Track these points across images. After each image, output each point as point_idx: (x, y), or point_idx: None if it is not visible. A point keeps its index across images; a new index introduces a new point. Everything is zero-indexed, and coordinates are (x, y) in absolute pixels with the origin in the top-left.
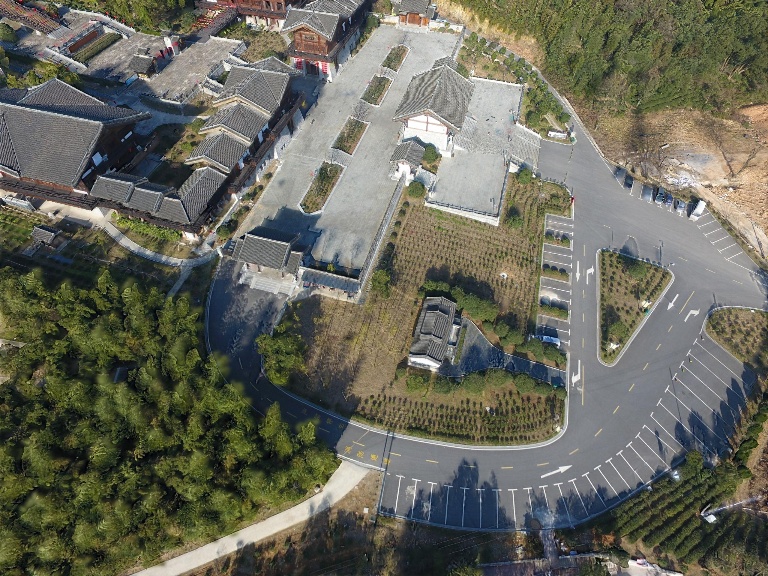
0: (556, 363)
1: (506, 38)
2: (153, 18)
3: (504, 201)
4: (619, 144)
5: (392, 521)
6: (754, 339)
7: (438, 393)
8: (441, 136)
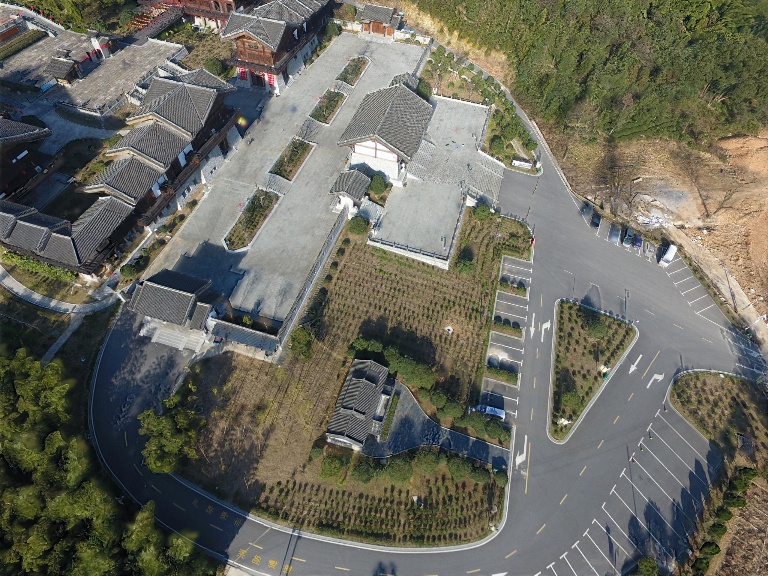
0: (499, 440)
1: (476, 53)
2: (88, 15)
3: (457, 240)
4: (588, 176)
5: None
6: (722, 411)
7: (356, 481)
8: (391, 164)
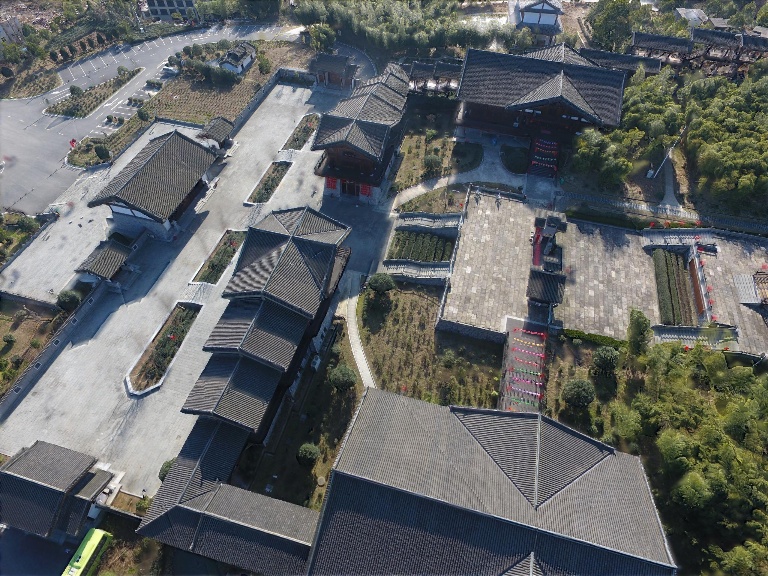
0: None
1: None
2: None
3: None
4: None
5: (277, 23)
6: None
7: None
8: None
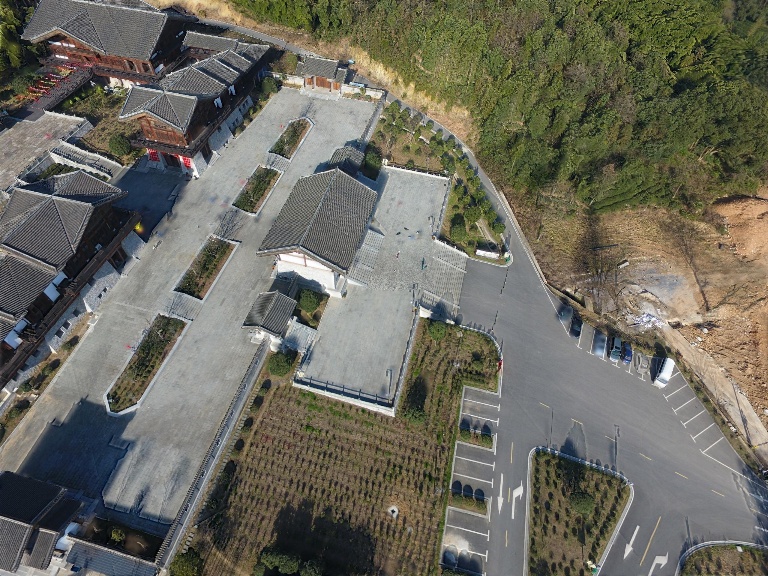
0: None
1: (435, 107)
2: None
3: (408, 369)
4: (567, 262)
5: None
6: None
7: None
8: (325, 273)
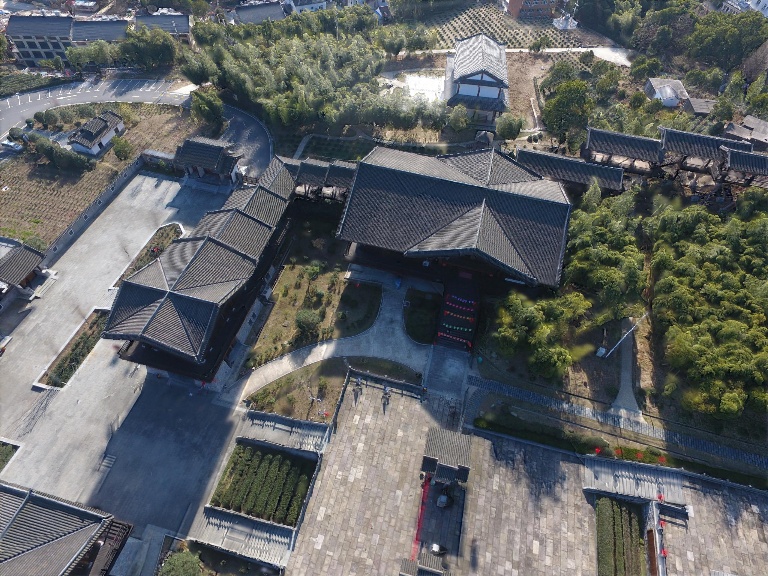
0: None
1: None
2: None
3: None
4: None
5: (166, 77)
6: None
7: None
8: None
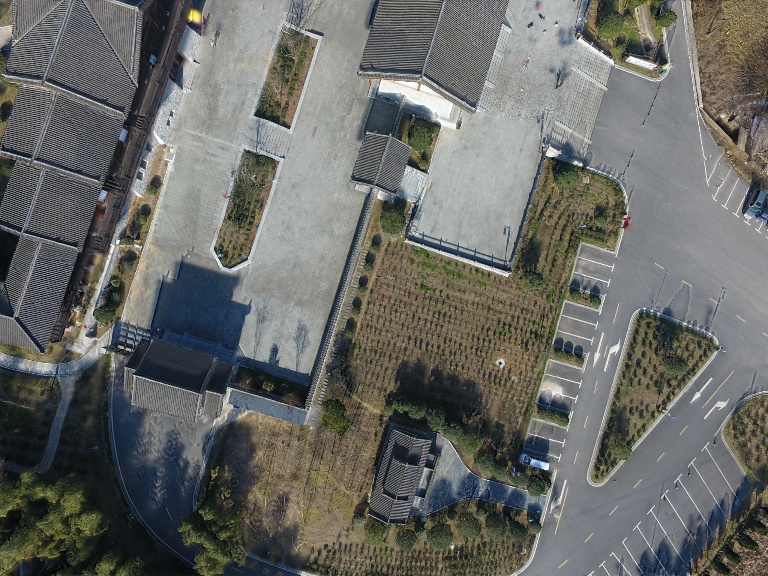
0: None
1: None
2: None
3: (525, 223)
4: (736, 74)
5: None
6: None
7: None
8: (442, 102)
